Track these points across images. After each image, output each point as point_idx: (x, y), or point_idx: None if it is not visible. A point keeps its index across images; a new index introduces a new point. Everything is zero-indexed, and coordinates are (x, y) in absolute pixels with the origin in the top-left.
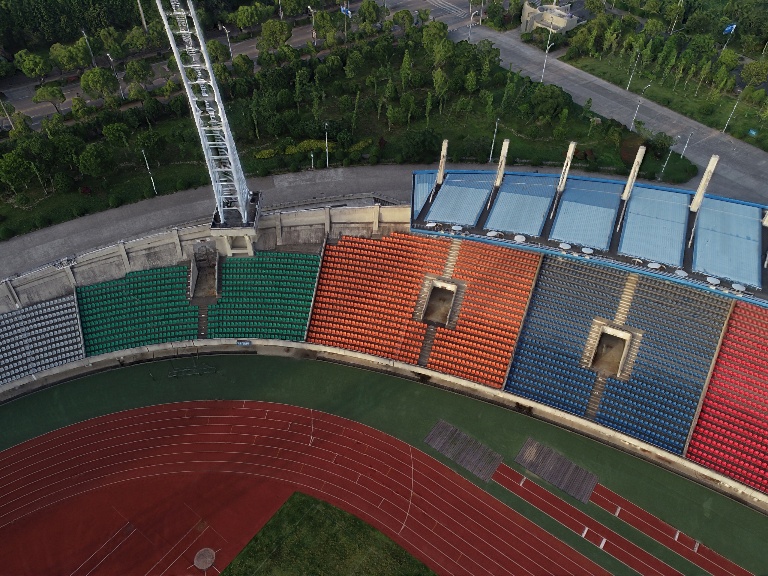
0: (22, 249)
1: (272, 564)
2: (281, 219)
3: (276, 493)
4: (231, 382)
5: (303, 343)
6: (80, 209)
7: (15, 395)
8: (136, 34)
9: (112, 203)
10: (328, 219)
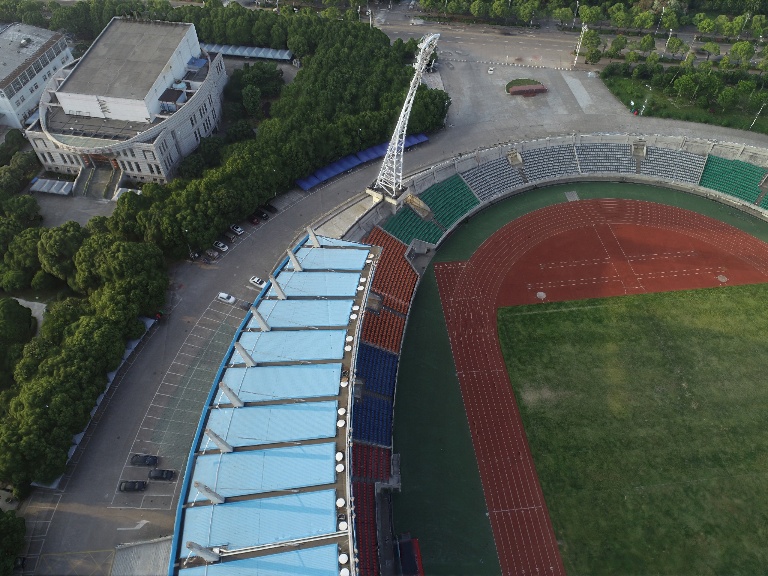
0: (671, 126)
1: (750, 296)
2: None
3: (762, 278)
4: (758, 231)
5: None
6: (707, 119)
7: (657, 185)
8: None
9: (724, 124)
10: None
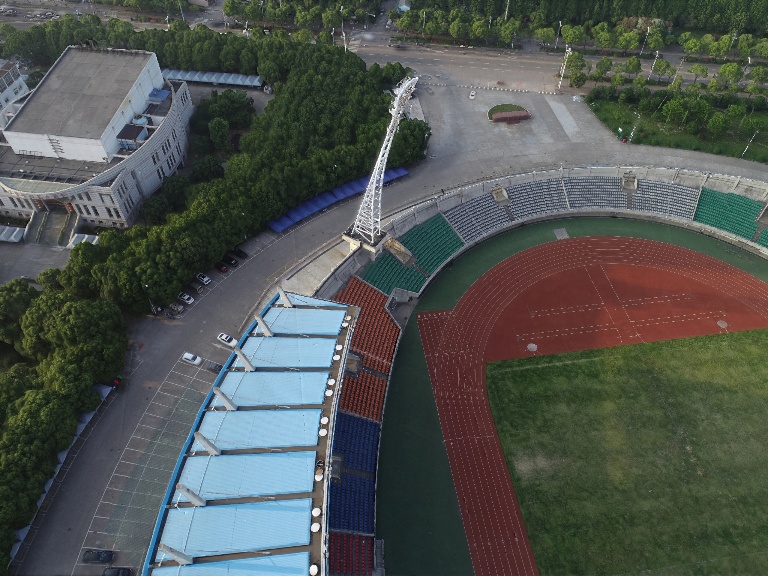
0: (660, 154)
1: (753, 343)
2: None
3: (764, 322)
4: (756, 269)
5: None
6: (697, 147)
7: (650, 220)
8: (766, 45)
9: (715, 151)
10: None
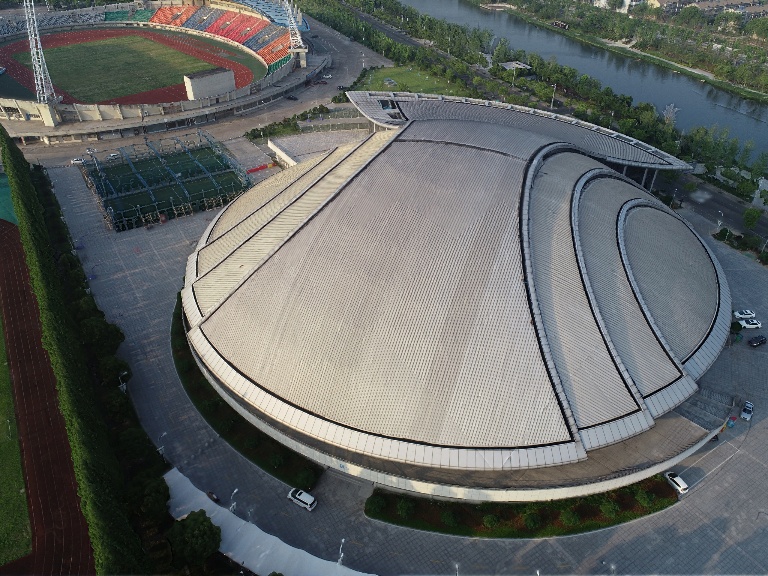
0: None
1: None
2: (151, 2)
3: None
4: None
5: (147, 22)
6: None
7: None
8: None
9: None
10: (161, 3)
